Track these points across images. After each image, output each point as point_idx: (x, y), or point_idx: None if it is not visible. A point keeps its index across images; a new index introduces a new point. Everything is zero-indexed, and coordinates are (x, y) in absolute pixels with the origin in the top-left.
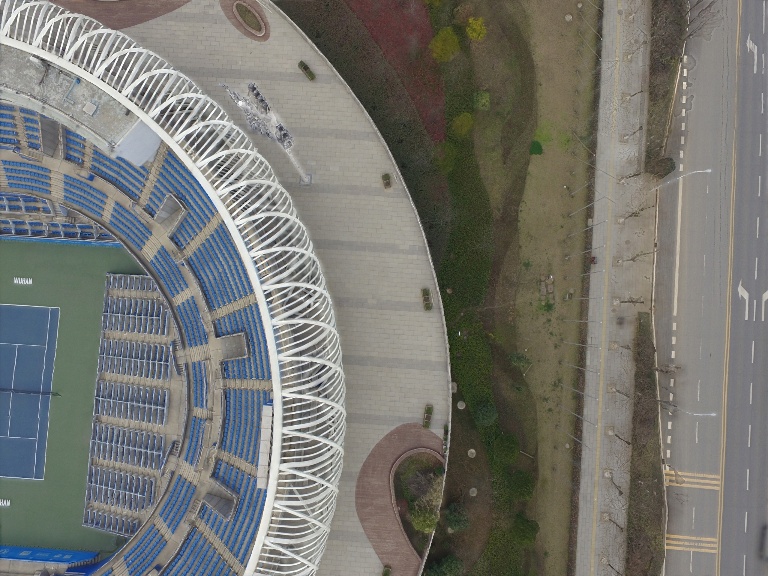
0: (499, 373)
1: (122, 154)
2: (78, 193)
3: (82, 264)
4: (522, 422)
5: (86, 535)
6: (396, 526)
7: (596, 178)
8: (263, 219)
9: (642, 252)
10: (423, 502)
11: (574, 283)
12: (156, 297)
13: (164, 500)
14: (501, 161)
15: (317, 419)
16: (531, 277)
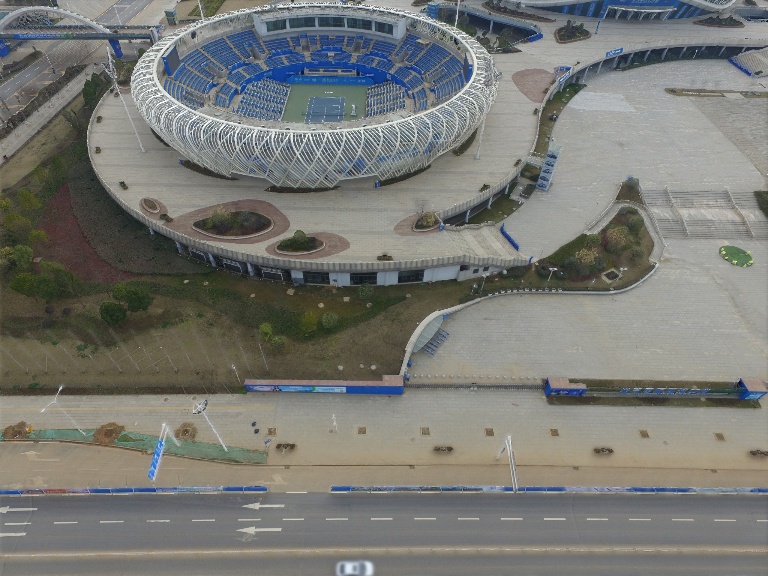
0: None
1: None
2: None
3: None
4: None
5: None
6: None
7: None
8: None
9: None
10: (130, 74)
11: None
12: None
13: None
14: None
15: None
16: None
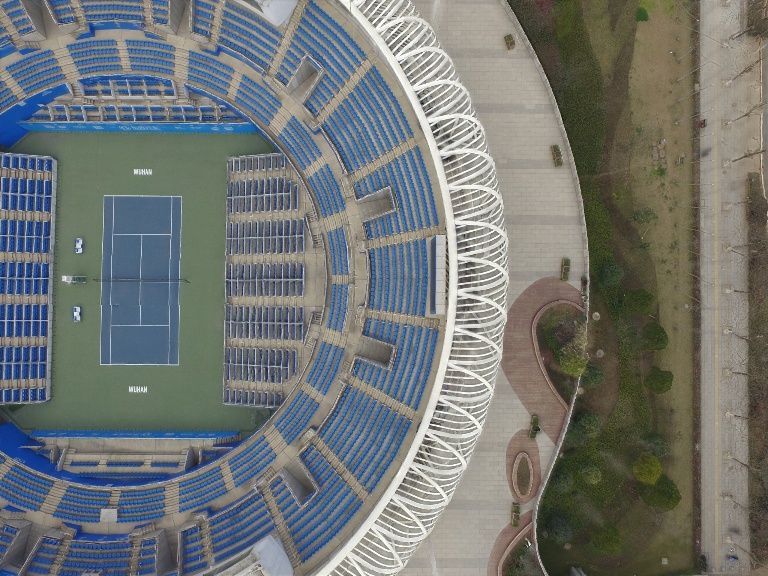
0: (618, 237)
1: (272, 4)
2: (203, 71)
3: (201, 152)
4: (643, 284)
5: (225, 416)
6: (540, 377)
7: (701, 43)
8: (423, 53)
9: (758, 105)
10: (570, 348)
11: (685, 147)
12: (282, 175)
13: (309, 368)
14: (610, 28)
15: (490, 245)
16: (644, 142)
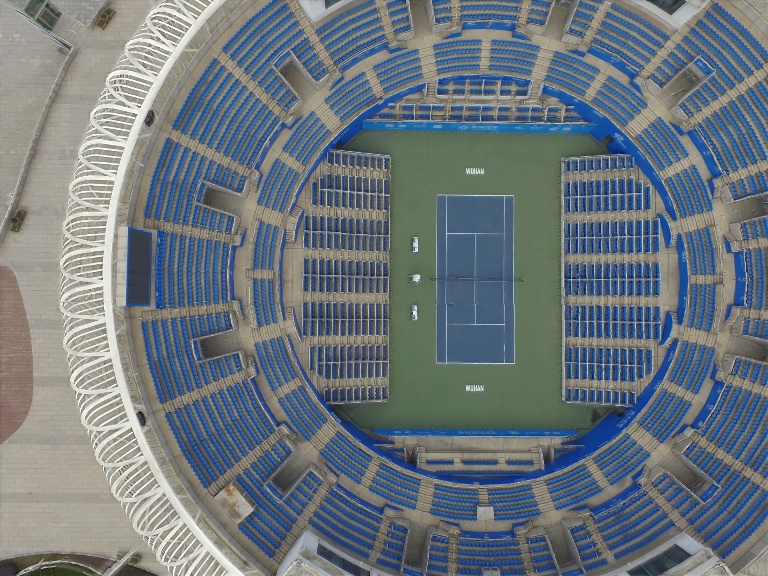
0: None
1: None
2: (565, 71)
3: (532, 152)
4: None
5: (561, 414)
6: None
7: None
8: None
9: None
10: None
11: None
12: (627, 176)
13: None
14: None
15: None
16: None
